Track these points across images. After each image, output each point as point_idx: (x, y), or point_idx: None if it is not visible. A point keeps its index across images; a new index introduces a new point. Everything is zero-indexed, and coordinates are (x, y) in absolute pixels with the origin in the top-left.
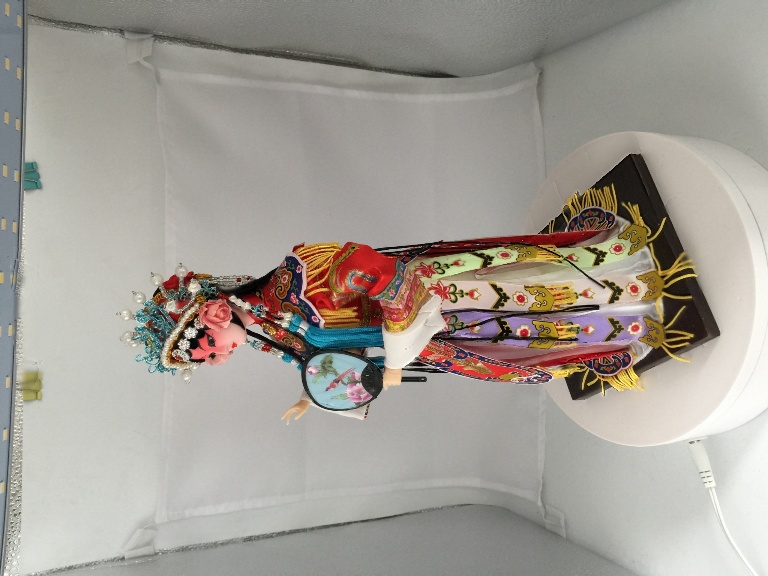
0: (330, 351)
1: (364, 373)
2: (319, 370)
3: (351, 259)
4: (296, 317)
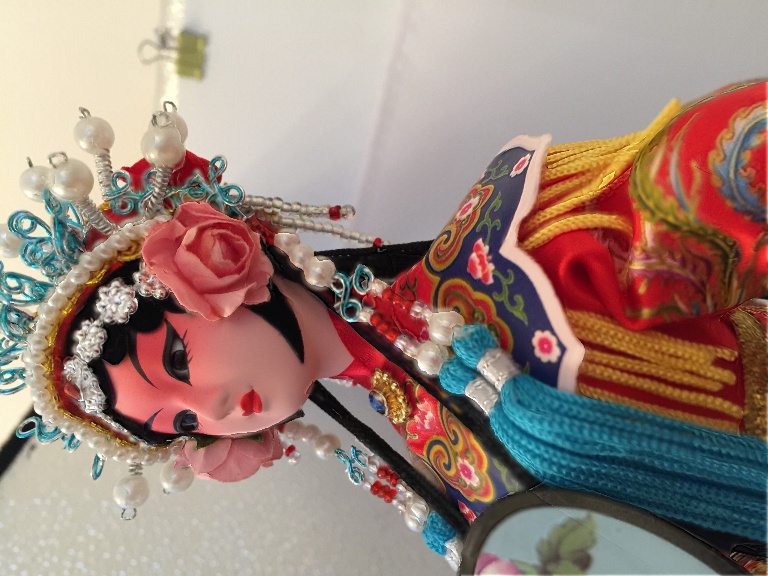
0: (586, 499)
1: None
2: None
3: (746, 89)
4: (472, 328)
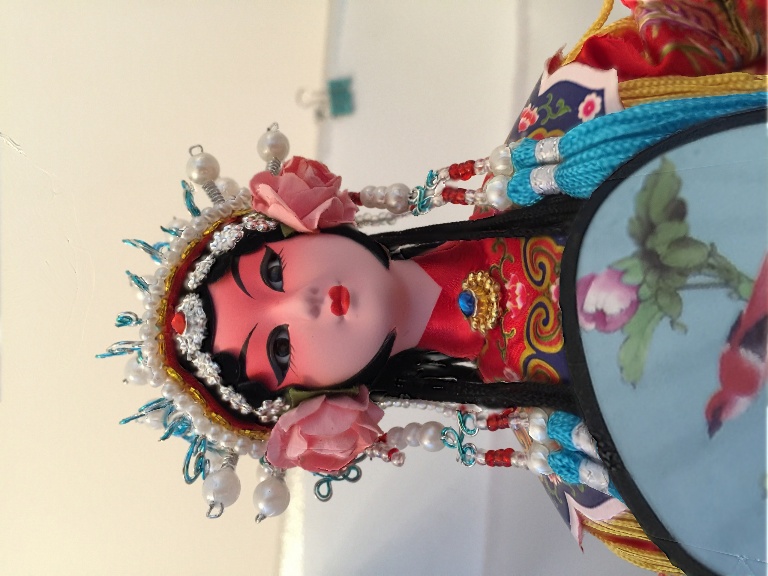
0: (655, 149)
1: None
2: (635, 288)
3: None
4: (526, 140)
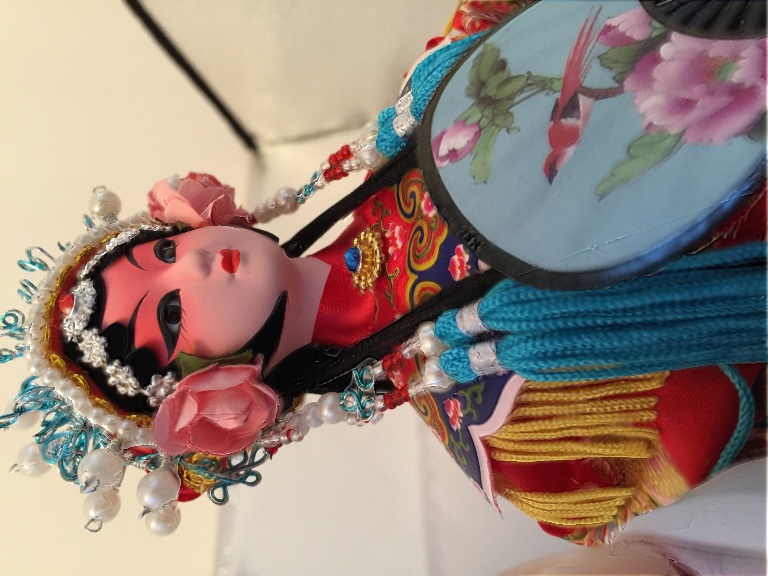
0: (478, 43)
1: (653, 1)
2: (476, 125)
3: None
4: None
